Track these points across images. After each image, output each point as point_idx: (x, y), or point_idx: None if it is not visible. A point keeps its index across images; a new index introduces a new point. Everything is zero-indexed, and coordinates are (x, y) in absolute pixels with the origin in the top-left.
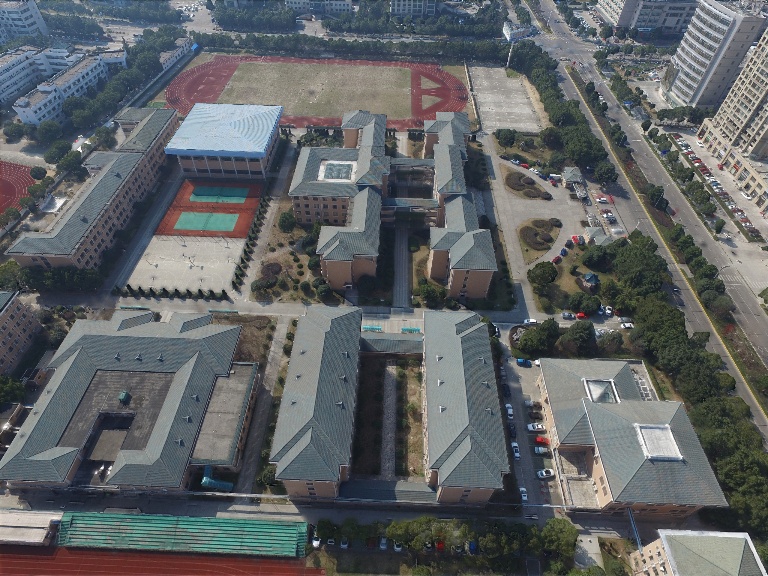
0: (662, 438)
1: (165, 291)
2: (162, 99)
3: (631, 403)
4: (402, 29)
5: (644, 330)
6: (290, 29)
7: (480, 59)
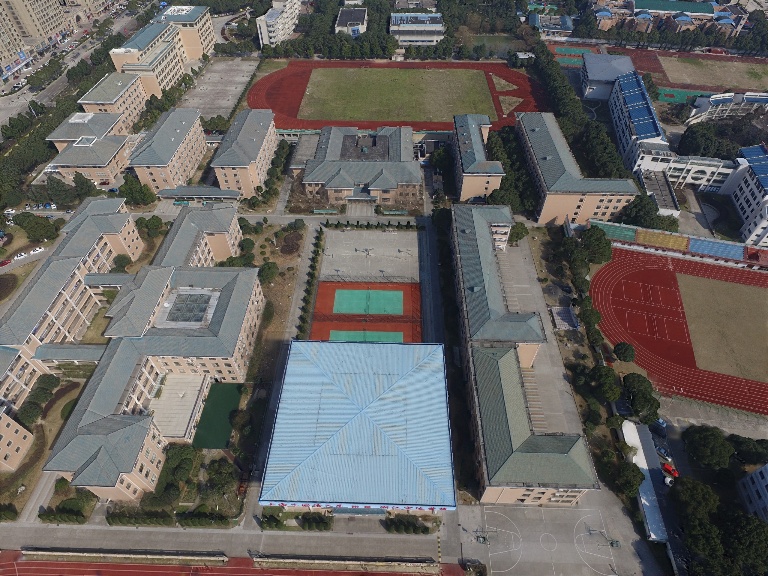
0: (78, 118)
1: (378, 224)
2: None
3: (75, 136)
4: None
5: (7, 193)
6: None
7: None
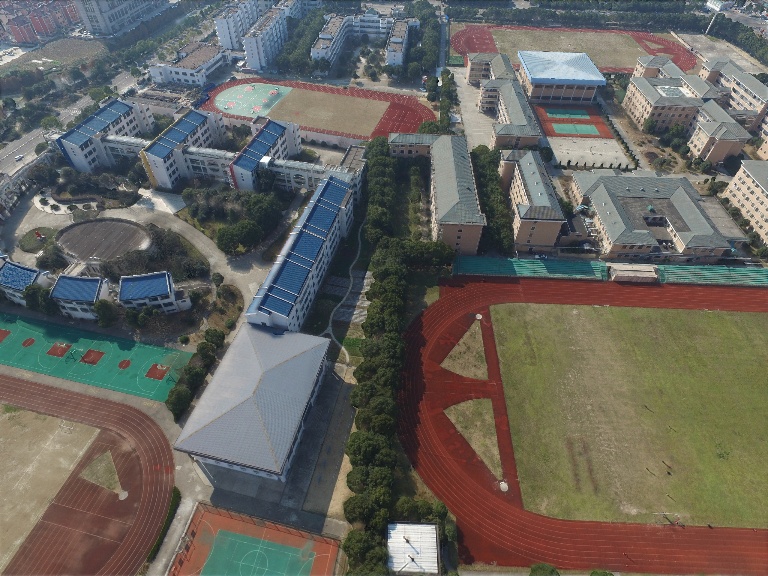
0: None
1: None
2: (457, 54)
3: None
4: (602, 6)
5: None
6: (505, 6)
7: (679, 28)
